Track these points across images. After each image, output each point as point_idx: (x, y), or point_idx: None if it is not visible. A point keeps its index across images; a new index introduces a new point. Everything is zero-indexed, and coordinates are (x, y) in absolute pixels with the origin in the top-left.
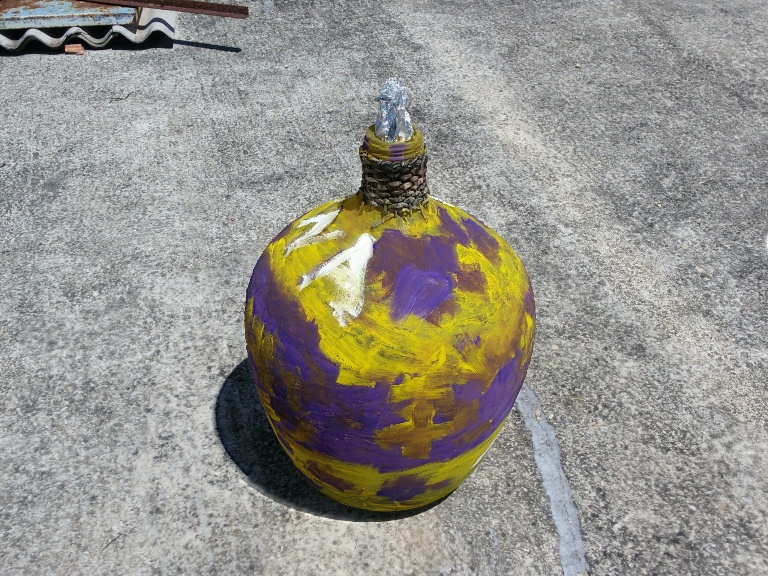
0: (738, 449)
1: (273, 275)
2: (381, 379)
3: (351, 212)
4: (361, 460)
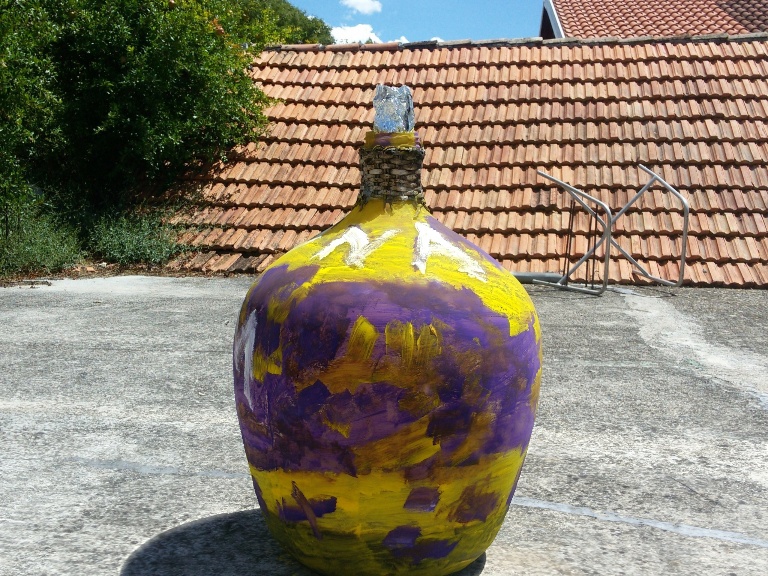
0: None
1: (374, 281)
2: (527, 321)
3: (379, 218)
4: (515, 442)
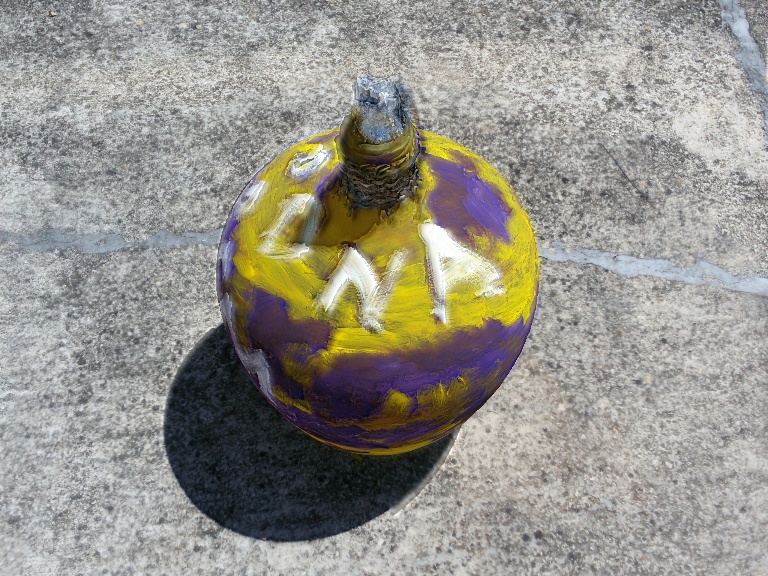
0: (429, 95)
1: (398, 351)
2: None
3: (376, 232)
4: None
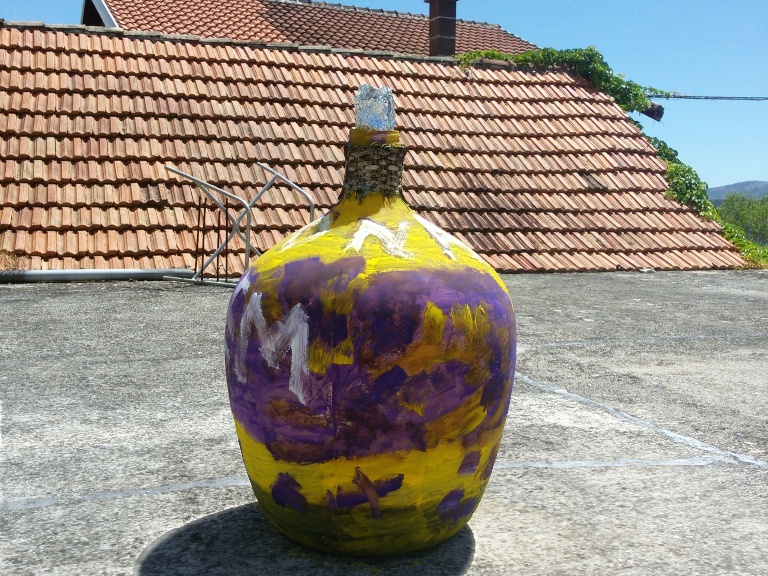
0: None
1: (427, 269)
2: None
3: (384, 211)
4: None
